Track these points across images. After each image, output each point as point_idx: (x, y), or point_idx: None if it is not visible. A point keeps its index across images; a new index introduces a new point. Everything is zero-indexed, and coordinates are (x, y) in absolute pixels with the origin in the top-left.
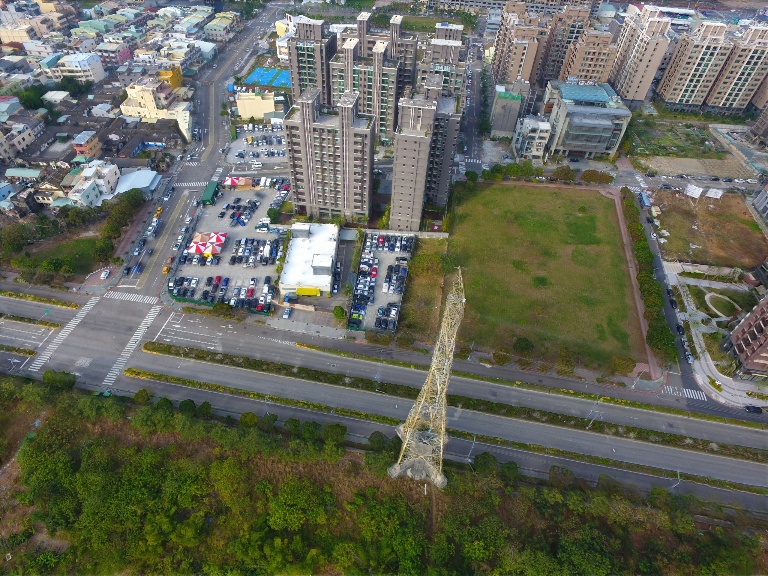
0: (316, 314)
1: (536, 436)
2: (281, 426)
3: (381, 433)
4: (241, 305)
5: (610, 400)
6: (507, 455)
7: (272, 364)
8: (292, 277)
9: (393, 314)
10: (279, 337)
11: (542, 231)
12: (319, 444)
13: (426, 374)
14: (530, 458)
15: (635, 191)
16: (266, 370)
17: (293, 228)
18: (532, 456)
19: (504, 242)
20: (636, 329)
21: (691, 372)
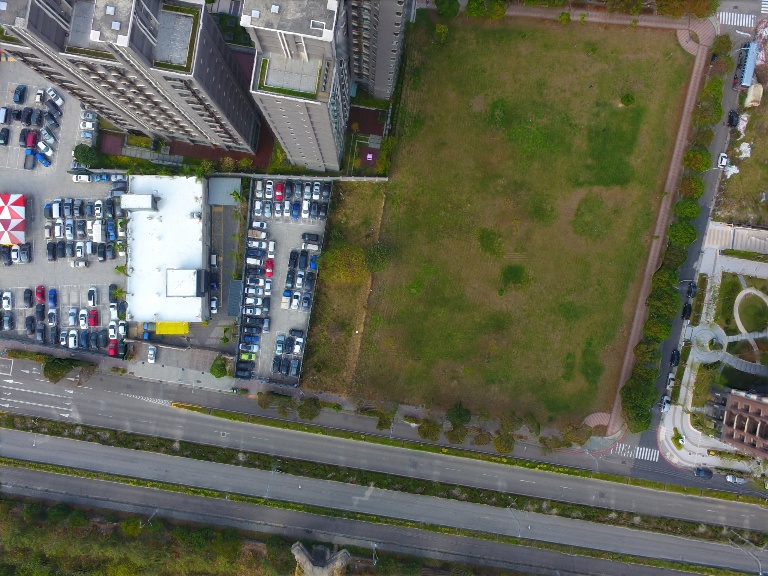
0: (192, 353)
1: (451, 515)
2: (172, 516)
3: (278, 541)
4: (85, 345)
5: (546, 469)
6: (415, 537)
7: (146, 440)
8: (144, 302)
9: (296, 352)
10: (149, 393)
11: (544, 156)
12: (213, 553)
13: (336, 441)
14: (439, 540)
15: (743, 29)
16: (141, 449)
17: (124, 205)
18: (441, 537)
19: (476, 187)
20: (617, 359)
21: (658, 424)
